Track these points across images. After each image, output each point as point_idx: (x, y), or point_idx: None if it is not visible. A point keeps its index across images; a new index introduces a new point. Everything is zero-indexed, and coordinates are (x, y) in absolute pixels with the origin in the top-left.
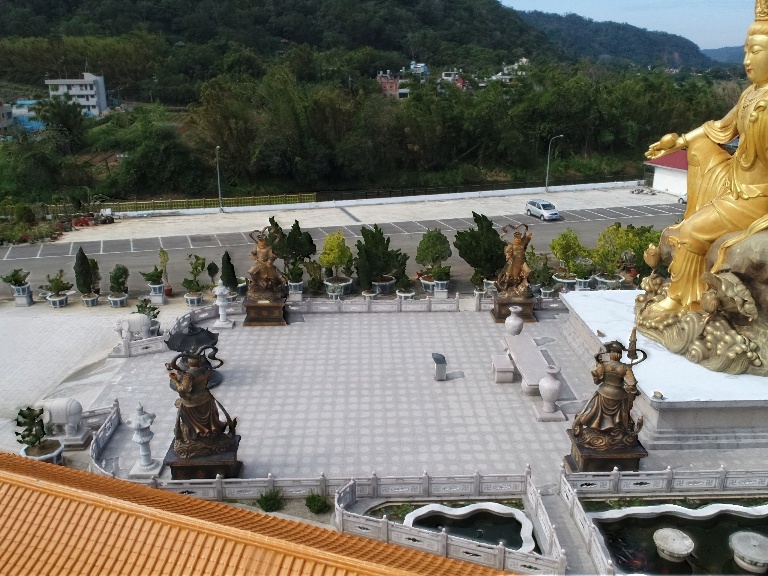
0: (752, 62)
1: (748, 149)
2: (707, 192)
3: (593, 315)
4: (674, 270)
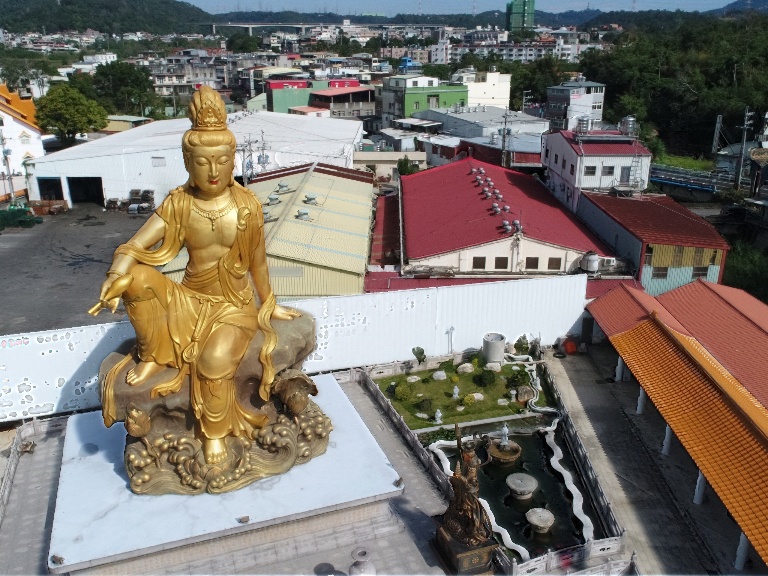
0: (221, 173)
1: (244, 257)
2: (180, 319)
3: (168, 529)
4: (219, 409)
